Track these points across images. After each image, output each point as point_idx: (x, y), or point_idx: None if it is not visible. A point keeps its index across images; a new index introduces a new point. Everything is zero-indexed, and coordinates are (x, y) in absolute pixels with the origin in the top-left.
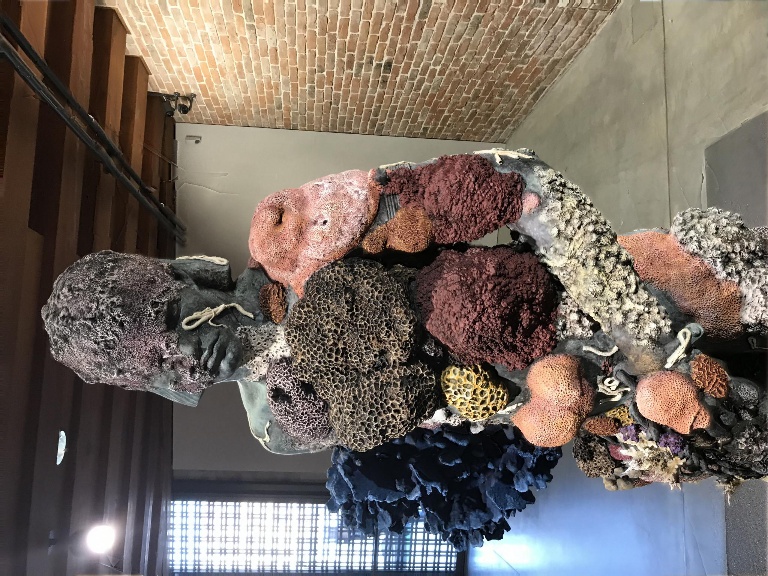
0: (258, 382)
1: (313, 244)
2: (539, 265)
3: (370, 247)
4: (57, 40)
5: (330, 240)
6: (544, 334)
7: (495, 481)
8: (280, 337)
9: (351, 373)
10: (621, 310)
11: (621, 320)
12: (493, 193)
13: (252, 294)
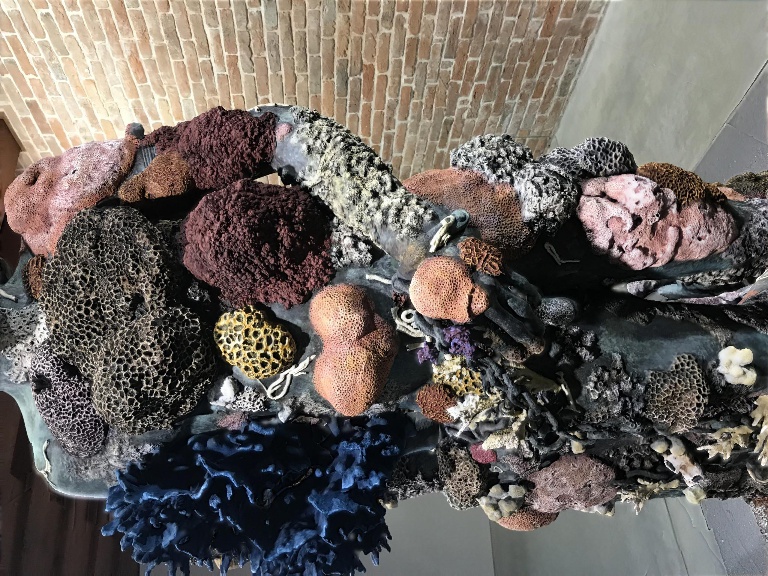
0: (28, 384)
1: (61, 193)
2: (301, 191)
3: (125, 195)
4: (9, 260)
5: (78, 186)
6: (315, 259)
7: (326, 492)
8: (42, 315)
9: (109, 333)
10: (381, 209)
11: (381, 217)
12: (241, 123)
13: (21, 281)
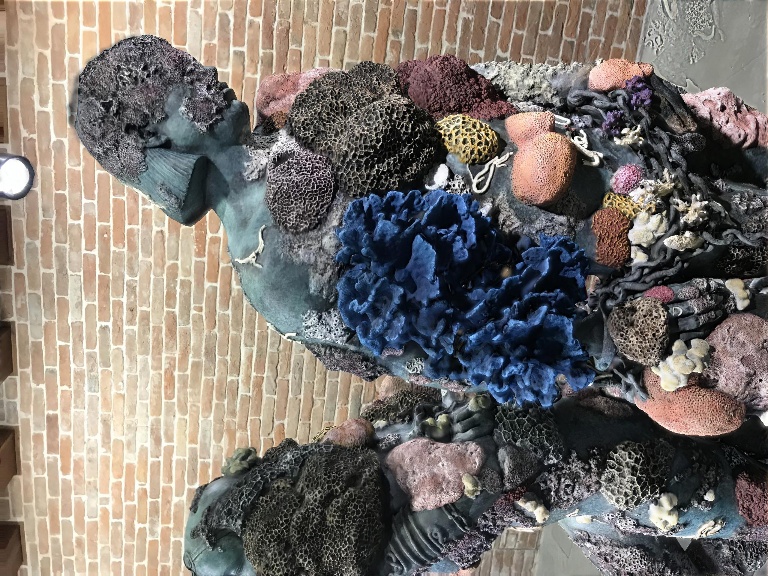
0: (256, 185)
1: None
2: None
3: None
4: None
5: None
6: None
7: None
8: (282, 136)
9: None
10: None
11: (552, 70)
12: None
13: None
